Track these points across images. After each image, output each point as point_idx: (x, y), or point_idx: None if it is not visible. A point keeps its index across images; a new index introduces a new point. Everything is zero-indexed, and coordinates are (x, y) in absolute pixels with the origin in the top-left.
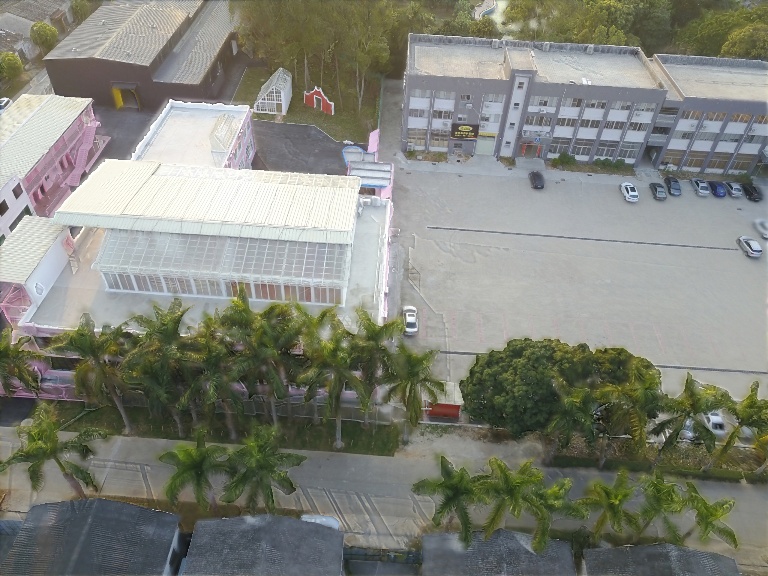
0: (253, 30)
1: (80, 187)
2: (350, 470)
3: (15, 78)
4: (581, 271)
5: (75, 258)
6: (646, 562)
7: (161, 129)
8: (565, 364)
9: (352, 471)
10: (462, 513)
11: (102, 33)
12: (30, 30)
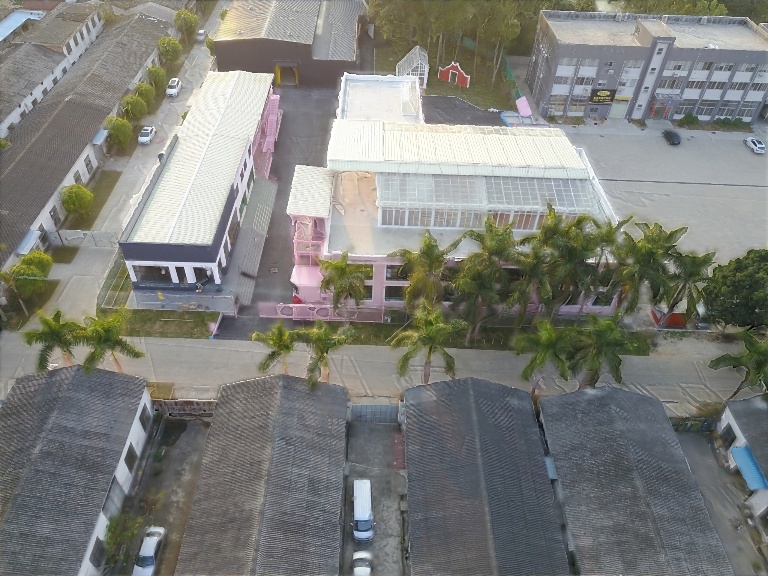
0: (395, 11)
1: (331, 141)
2: (619, 367)
3: (173, 61)
4: (738, 210)
5: (337, 202)
6: None
7: (348, 98)
8: None
9: (621, 367)
10: (767, 377)
11: (255, 17)
12: (175, 18)
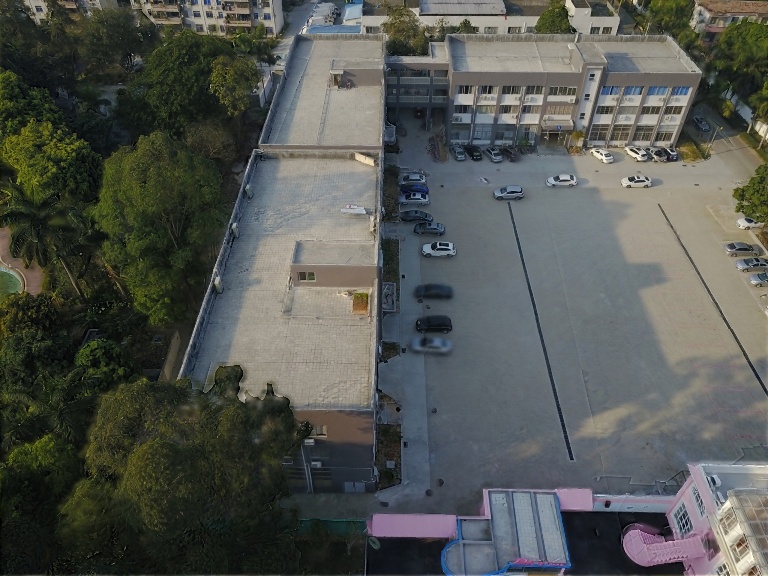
0: None
1: None
2: None
3: None
4: (596, 313)
5: None
6: None
7: None
8: None
9: None
10: None
11: None
12: None
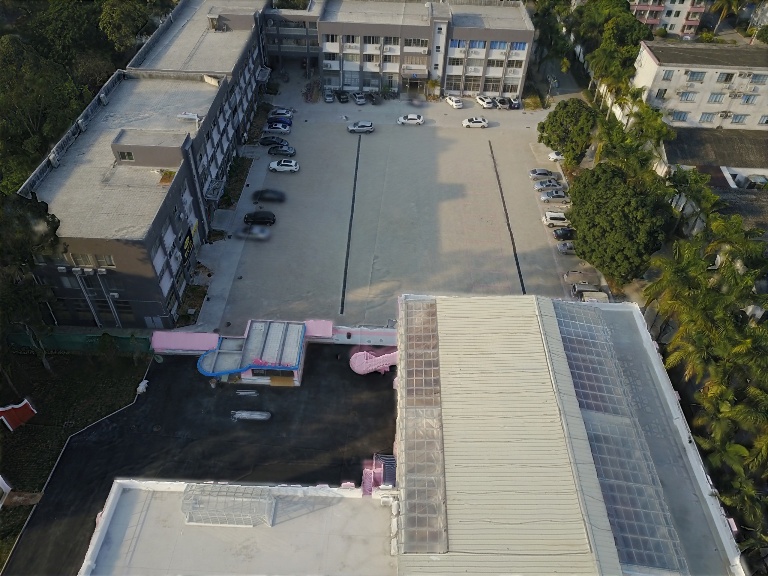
0: None
1: None
2: None
3: None
4: (402, 216)
5: None
6: (717, 210)
7: None
8: (638, 191)
9: None
10: None
11: None
12: None
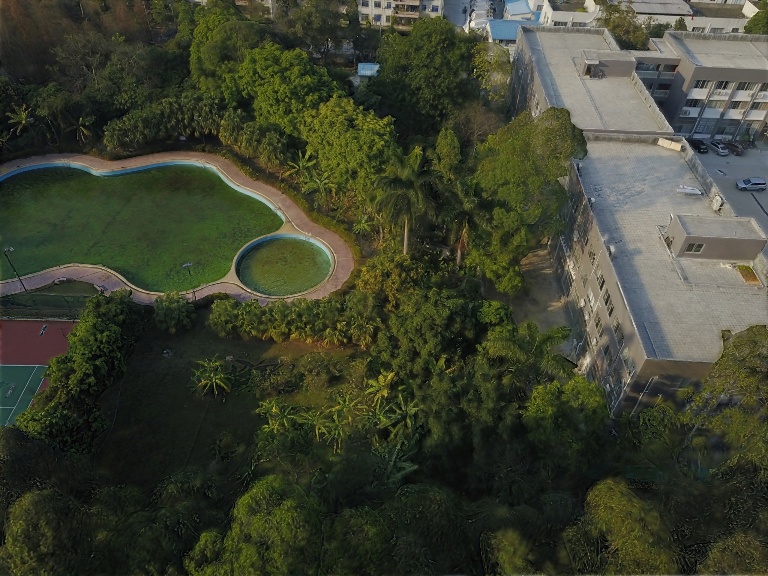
0: None
1: None
2: None
3: None
4: None
5: None
6: None
7: None
8: None
9: None
10: None
11: None
12: None
